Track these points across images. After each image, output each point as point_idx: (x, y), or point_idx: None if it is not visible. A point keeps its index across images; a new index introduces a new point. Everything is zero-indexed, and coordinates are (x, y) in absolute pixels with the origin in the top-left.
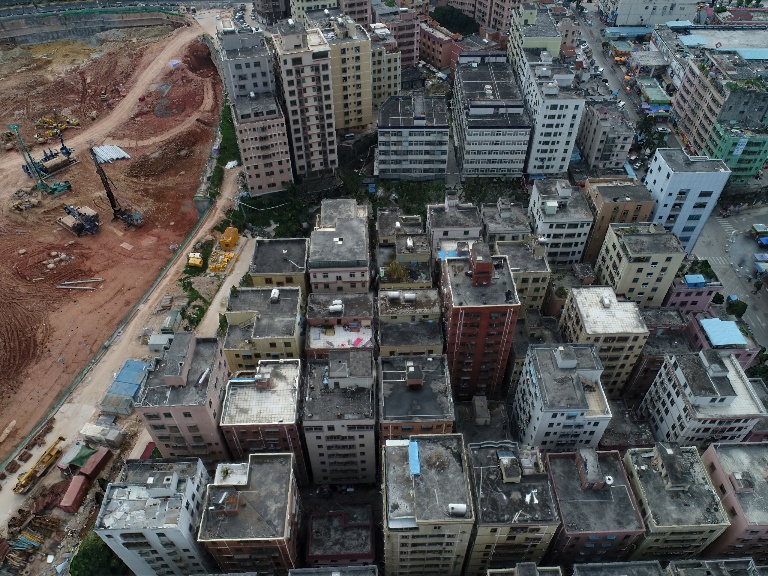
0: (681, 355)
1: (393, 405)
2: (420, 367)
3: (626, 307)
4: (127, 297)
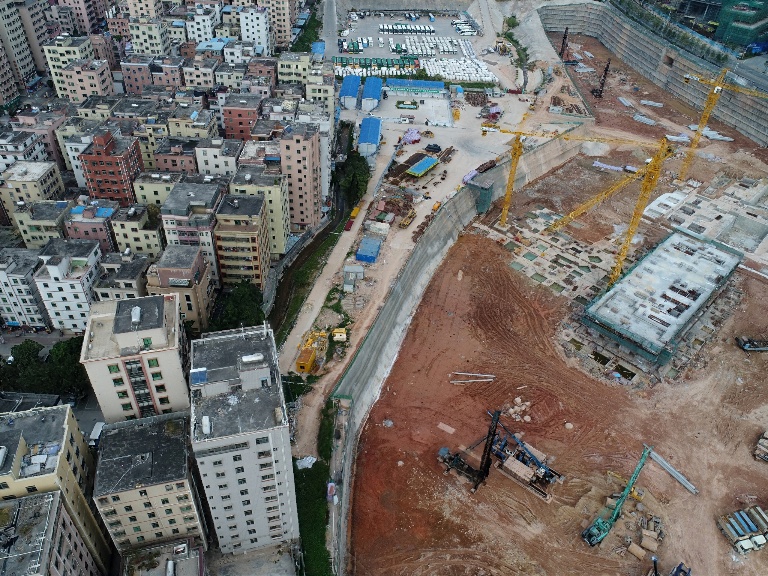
0: (18, 144)
1: (194, 145)
2: (172, 146)
3: (12, 171)
4: (418, 363)
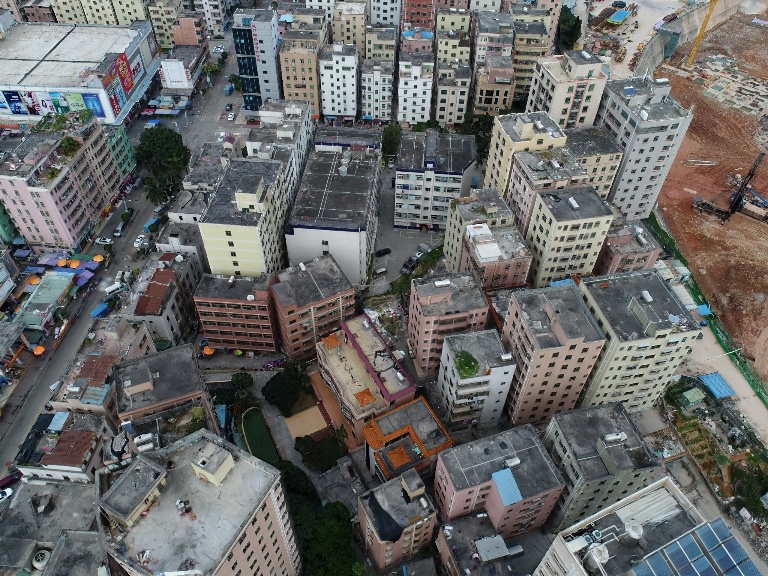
0: None
1: None
2: None
3: (340, 8)
4: None
